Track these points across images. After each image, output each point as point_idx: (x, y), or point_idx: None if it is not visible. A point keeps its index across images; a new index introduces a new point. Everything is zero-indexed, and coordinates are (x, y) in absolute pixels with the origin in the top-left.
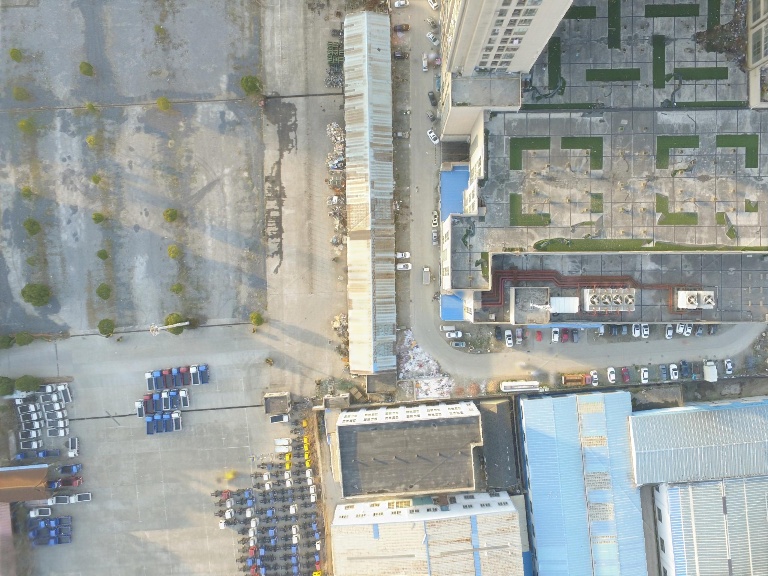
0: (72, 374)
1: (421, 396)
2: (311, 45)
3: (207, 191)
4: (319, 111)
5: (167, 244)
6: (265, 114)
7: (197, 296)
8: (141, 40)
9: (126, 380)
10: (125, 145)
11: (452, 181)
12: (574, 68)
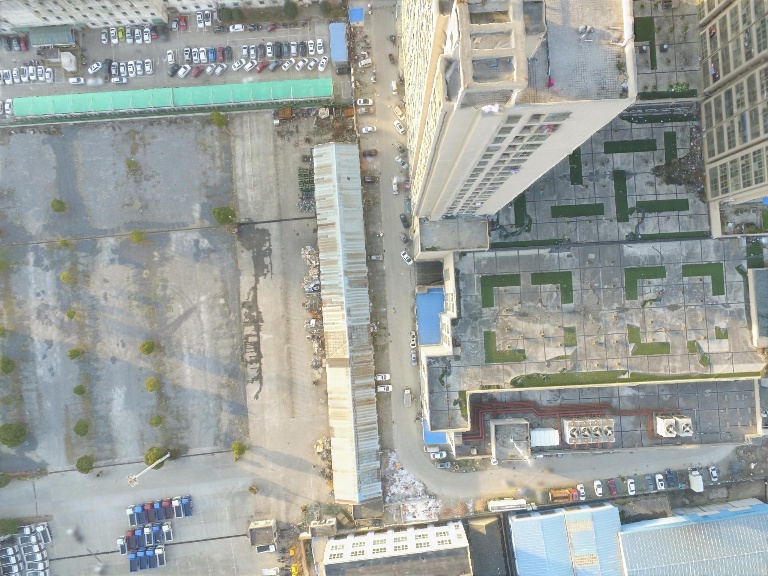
0: (51, 512)
1: (409, 519)
2: (282, 171)
3: (184, 319)
4: (293, 235)
5: (145, 375)
6: (239, 240)
7: (177, 426)
8: (113, 173)
9: (107, 516)
10: (99, 277)
11: (428, 303)
12: (539, 205)
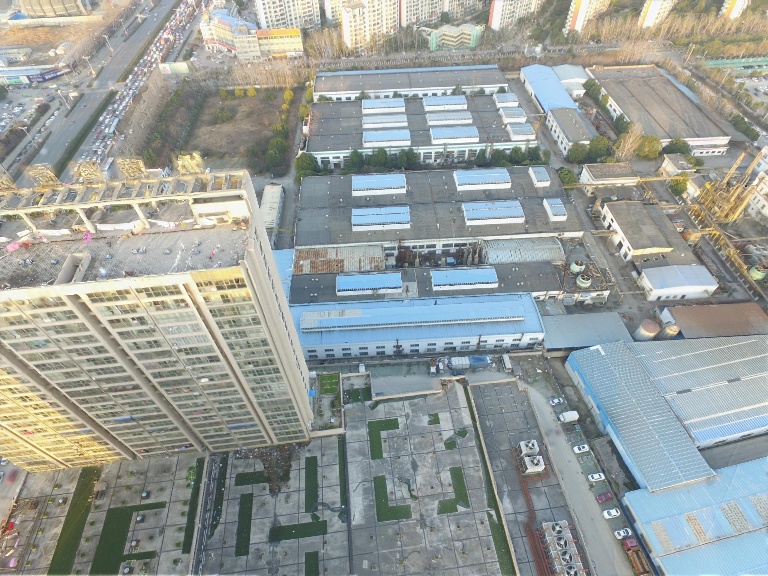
0: None
1: None
2: None
3: None
4: None
5: None
6: None
7: None
8: None
9: None
10: None
11: None
12: None
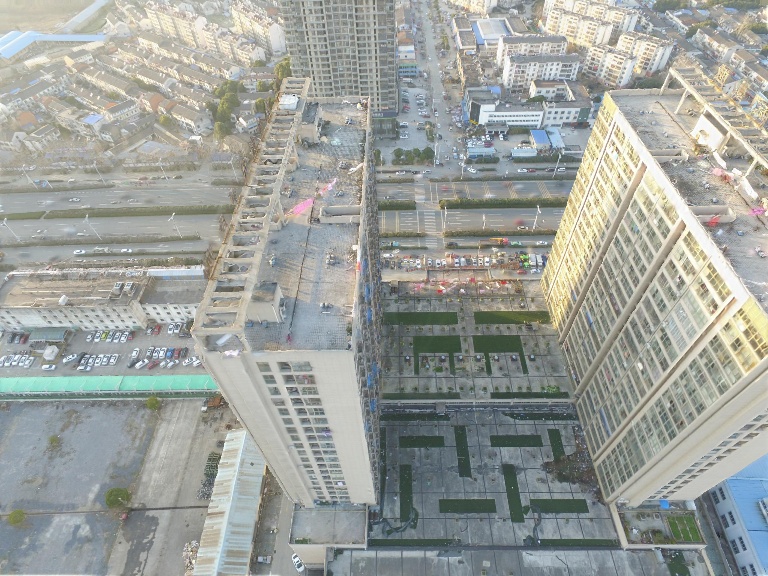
0: None
1: None
2: (195, 455)
3: None
4: (182, 526)
5: None
6: (123, 529)
7: None
8: (33, 448)
9: None
10: None
11: None
12: (426, 498)
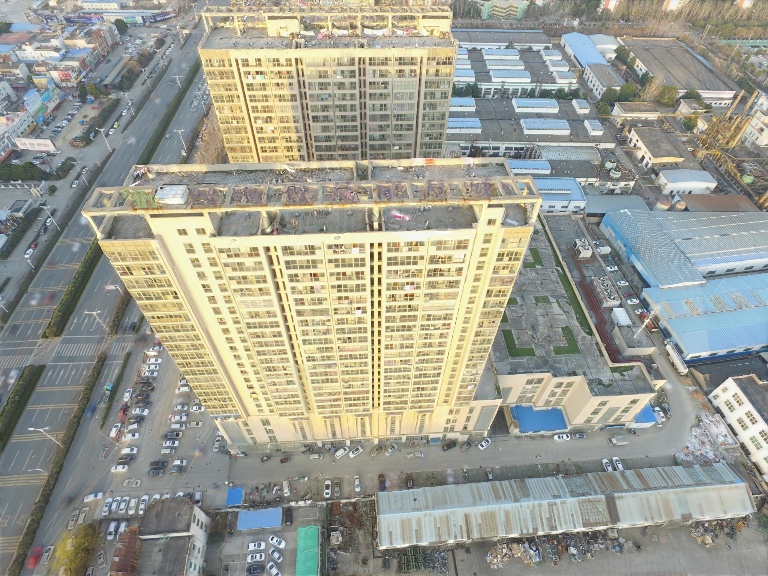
0: None
1: (731, 441)
2: None
3: None
4: None
5: None
6: None
7: None
8: None
9: None
10: None
11: (526, 421)
12: None
